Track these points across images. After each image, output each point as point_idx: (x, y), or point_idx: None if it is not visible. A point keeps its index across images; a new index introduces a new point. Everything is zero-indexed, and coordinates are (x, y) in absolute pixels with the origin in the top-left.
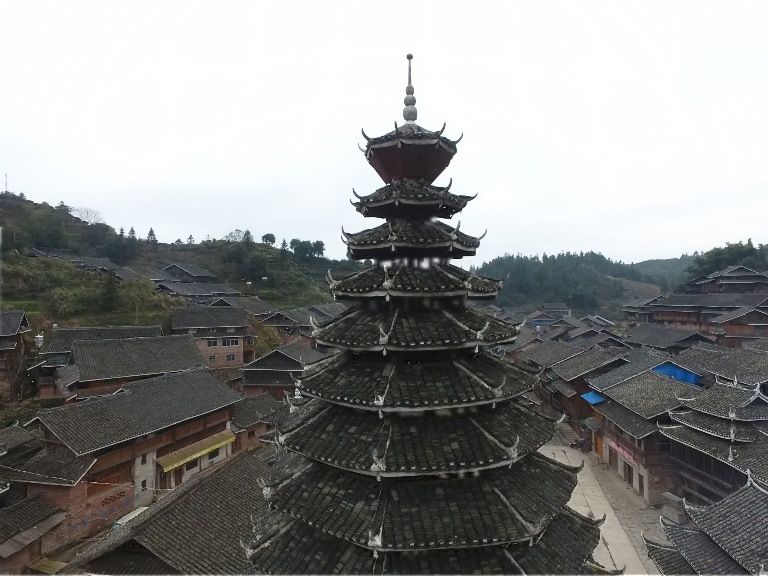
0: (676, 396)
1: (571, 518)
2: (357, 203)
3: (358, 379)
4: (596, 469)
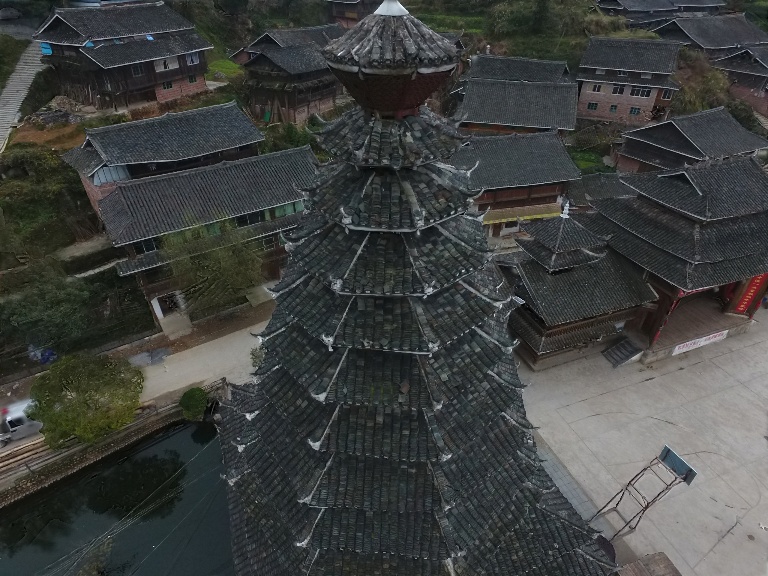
0: None
1: (436, 524)
2: None
3: None
4: None
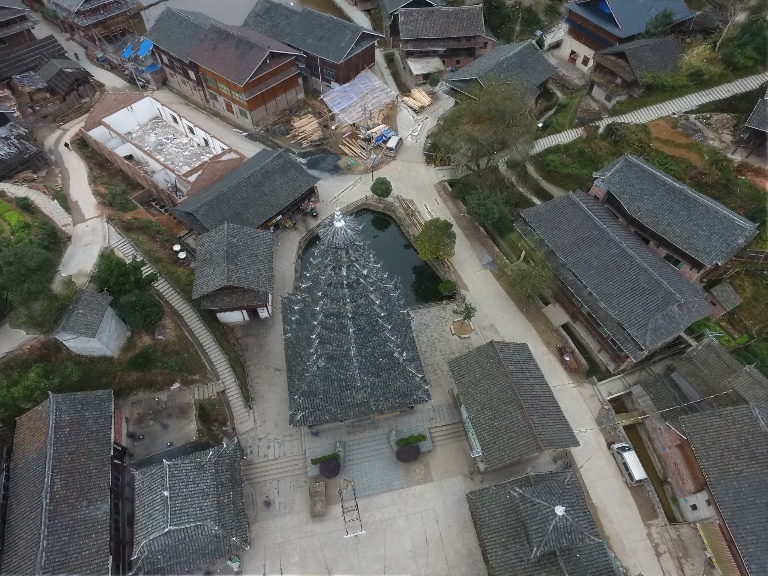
0: None
1: None
2: None
3: None
4: None
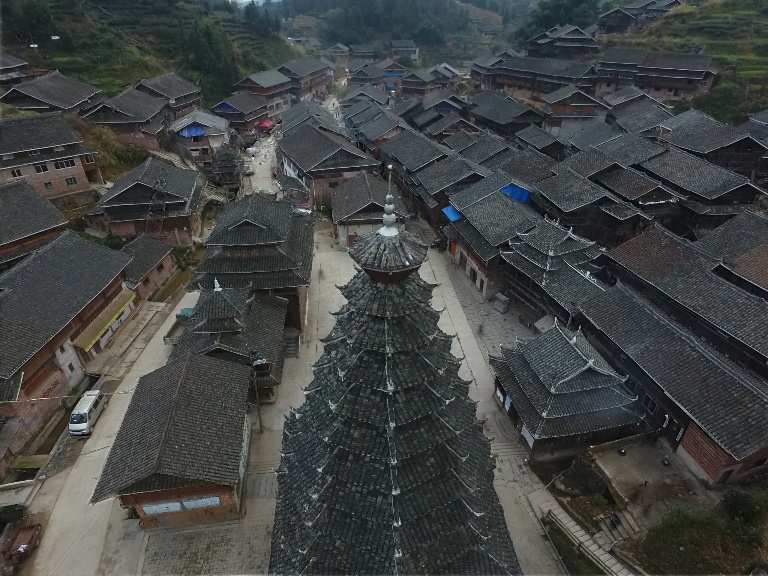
0: (516, 231)
1: None
2: (342, 289)
3: (368, 432)
4: (450, 269)
